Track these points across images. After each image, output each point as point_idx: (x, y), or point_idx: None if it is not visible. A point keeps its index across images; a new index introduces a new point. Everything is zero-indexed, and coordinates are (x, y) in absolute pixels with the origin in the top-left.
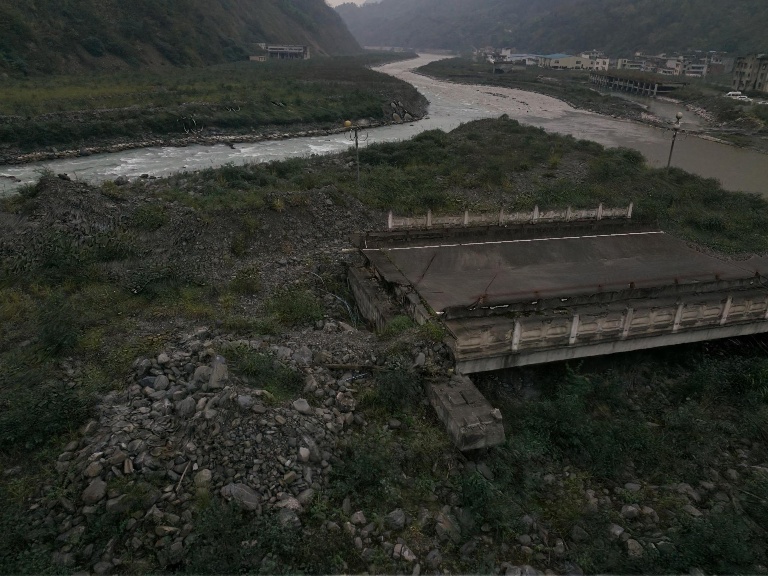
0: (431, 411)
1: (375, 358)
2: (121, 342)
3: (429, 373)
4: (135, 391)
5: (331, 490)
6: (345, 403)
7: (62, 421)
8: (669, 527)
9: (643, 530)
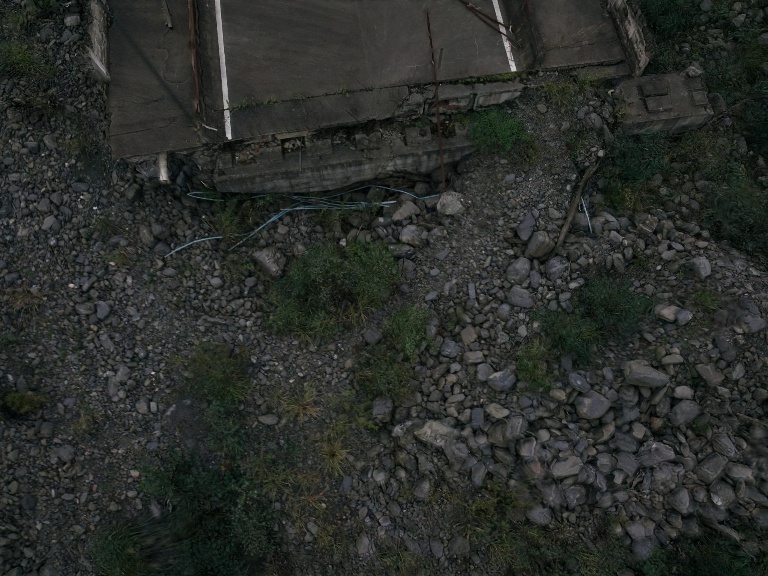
0: (639, 139)
1: (575, 175)
2: (415, 575)
3: (617, 119)
4: (622, 499)
5: (761, 257)
6: (656, 224)
7: (726, 574)
8: (751, 1)
9: (753, 21)
